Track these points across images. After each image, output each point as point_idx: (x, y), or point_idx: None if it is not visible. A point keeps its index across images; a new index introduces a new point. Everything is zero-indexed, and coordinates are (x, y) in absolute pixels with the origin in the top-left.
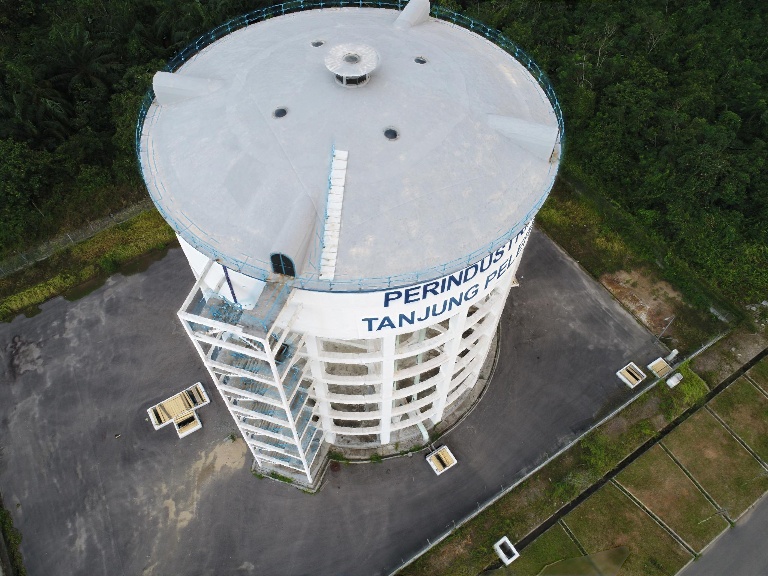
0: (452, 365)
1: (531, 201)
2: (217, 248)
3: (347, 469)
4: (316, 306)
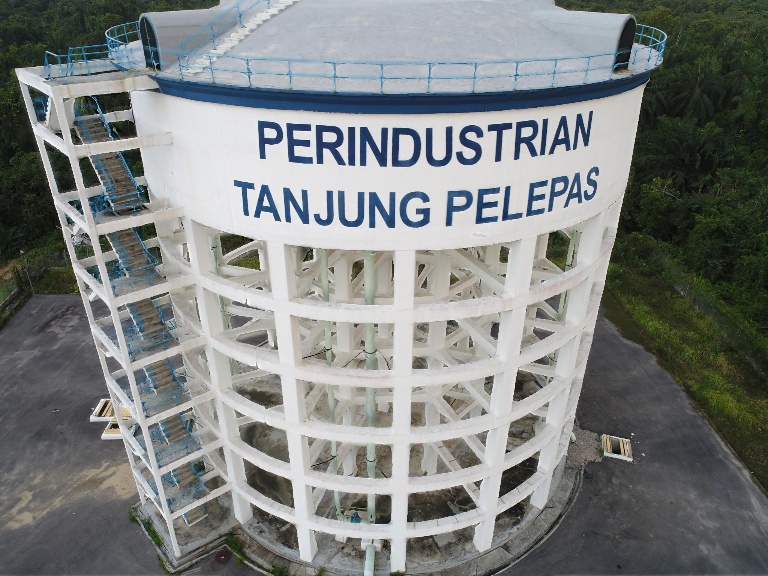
0: (405, 411)
1: (547, 82)
2: (125, 56)
3: (235, 568)
4: (184, 140)
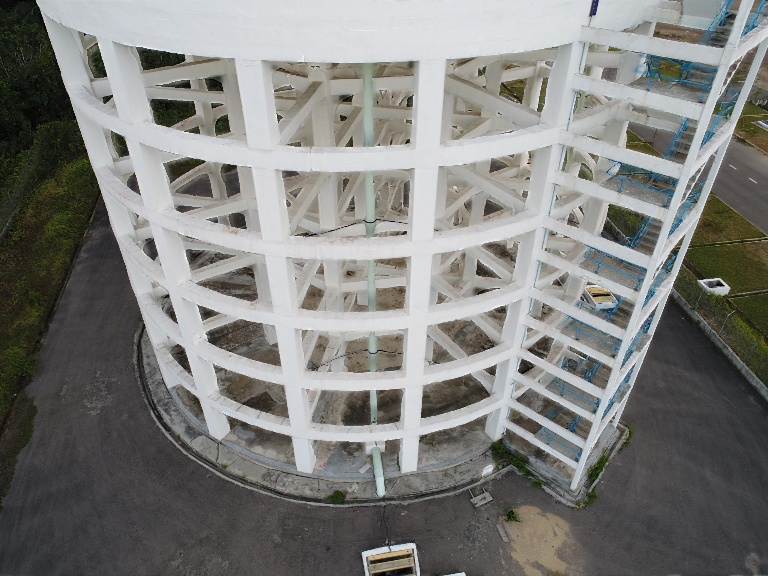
0: None
1: None
2: None
3: None
4: None
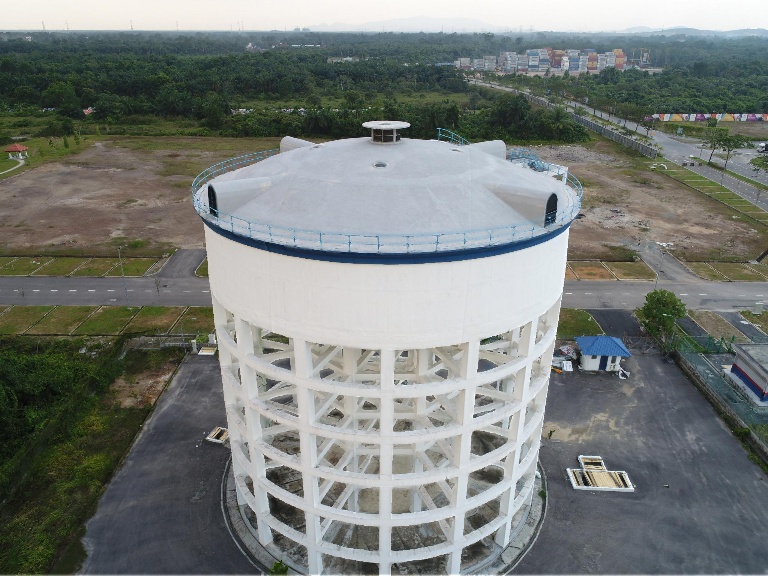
0: None
1: None
2: None
3: None
4: None
